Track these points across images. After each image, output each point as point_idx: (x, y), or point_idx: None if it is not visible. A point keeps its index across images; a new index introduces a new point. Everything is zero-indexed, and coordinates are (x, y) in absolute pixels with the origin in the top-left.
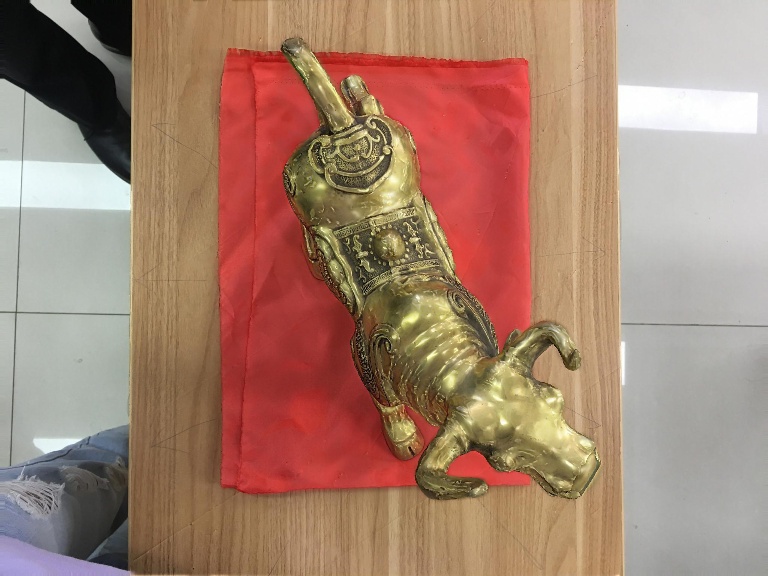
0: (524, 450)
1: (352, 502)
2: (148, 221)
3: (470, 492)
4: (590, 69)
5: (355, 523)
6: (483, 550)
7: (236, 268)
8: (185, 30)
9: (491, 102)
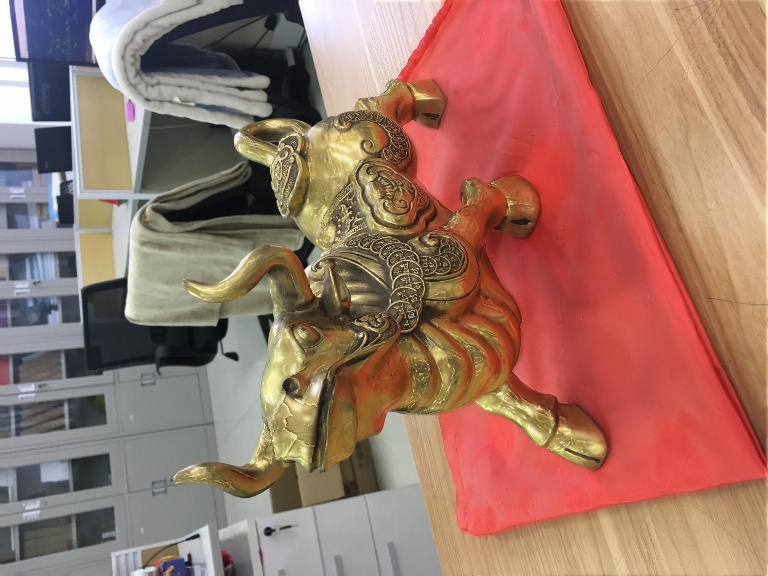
0: None
1: (571, 539)
2: None
3: None
4: None
5: (584, 568)
6: None
7: None
8: None
9: None
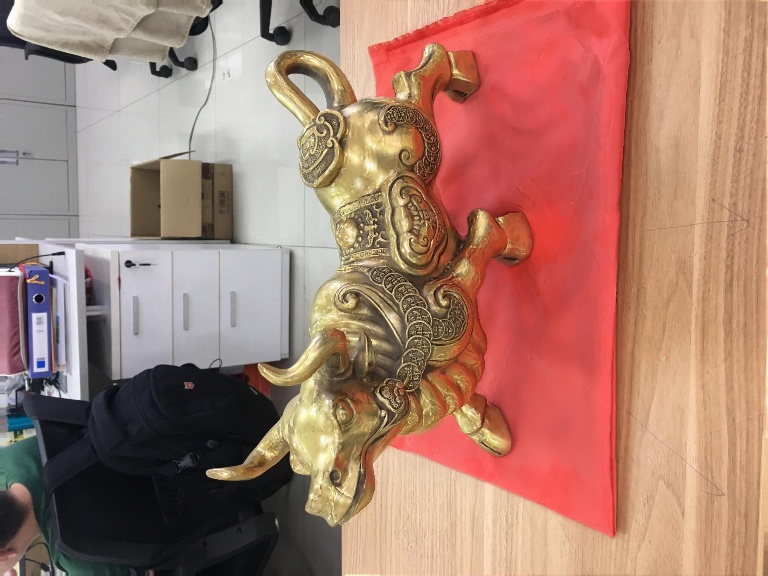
0: None
1: (458, 482)
2: None
3: None
4: None
5: (460, 503)
6: None
7: None
8: (363, 36)
9: (586, 23)
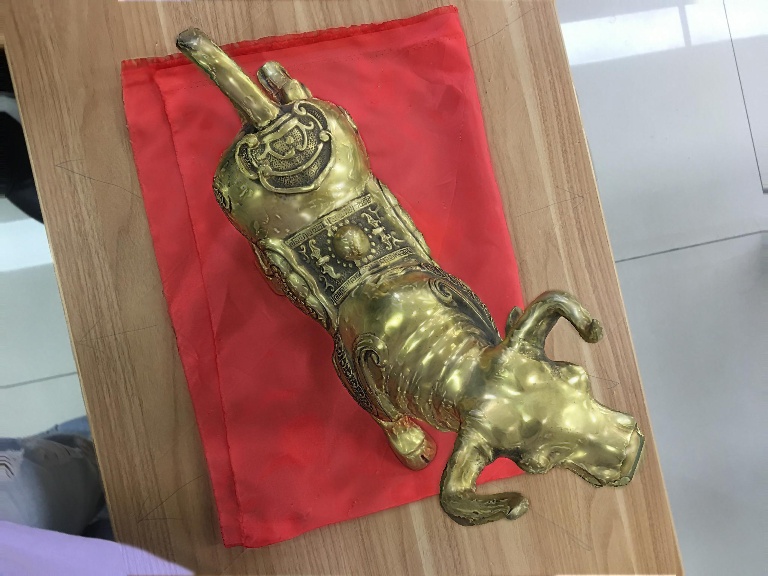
0: (557, 444)
1: (373, 528)
2: (76, 274)
3: (510, 514)
4: (525, 3)
5: (381, 550)
6: (524, 545)
7: (187, 304)
8: (69, 51)
9: (427, 61)
